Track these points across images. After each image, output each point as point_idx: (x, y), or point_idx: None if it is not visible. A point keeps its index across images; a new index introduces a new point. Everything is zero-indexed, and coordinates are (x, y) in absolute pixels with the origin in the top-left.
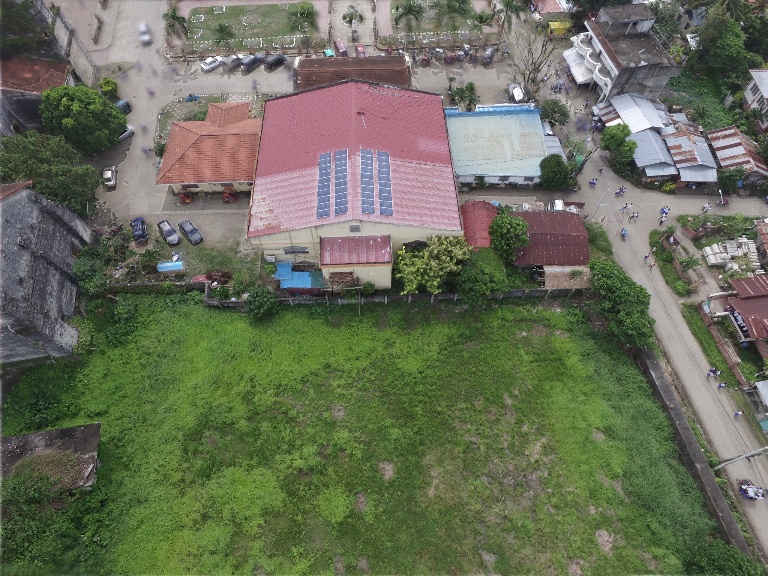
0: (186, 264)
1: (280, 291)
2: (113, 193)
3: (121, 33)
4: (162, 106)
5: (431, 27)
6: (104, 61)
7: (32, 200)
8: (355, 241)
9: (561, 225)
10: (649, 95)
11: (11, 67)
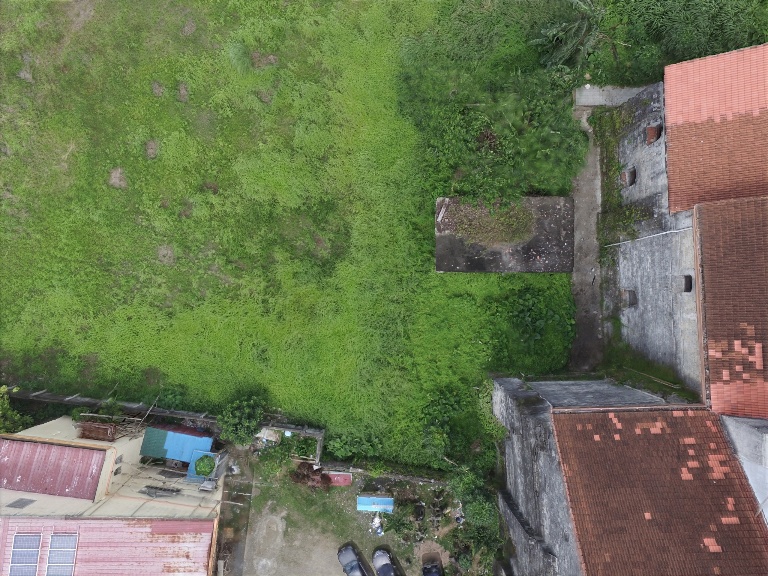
0: None
1: None
2: None
3: None
4: None
5: None
6: None
7: None
8: (44, 485)
9: None
10: None
11: None
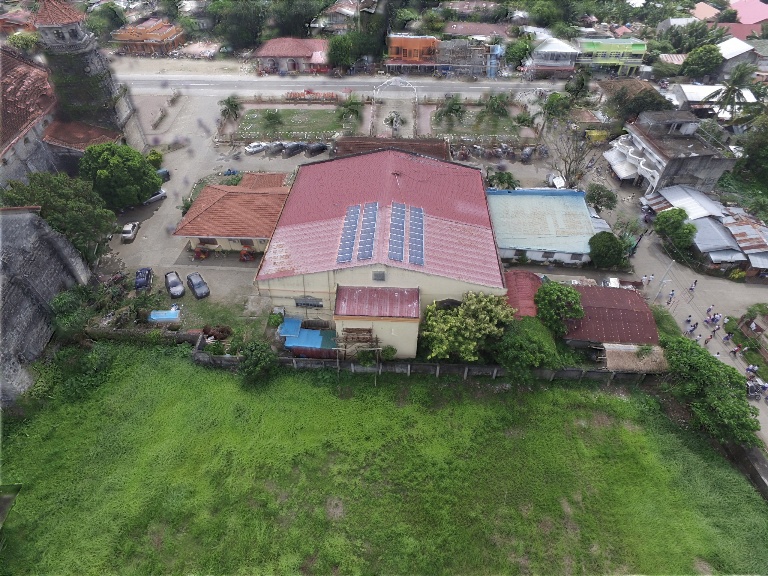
0: (185, 316)
1: (284, 352)
2: (129, 245)
3: (179, 123)
4: (200, 177)
5: (469, 131)
6: (157, 142)
7: (35, 224)
8: (377, 292)
9: (620, 301)
10: (702, 188)
11: (66, 129)
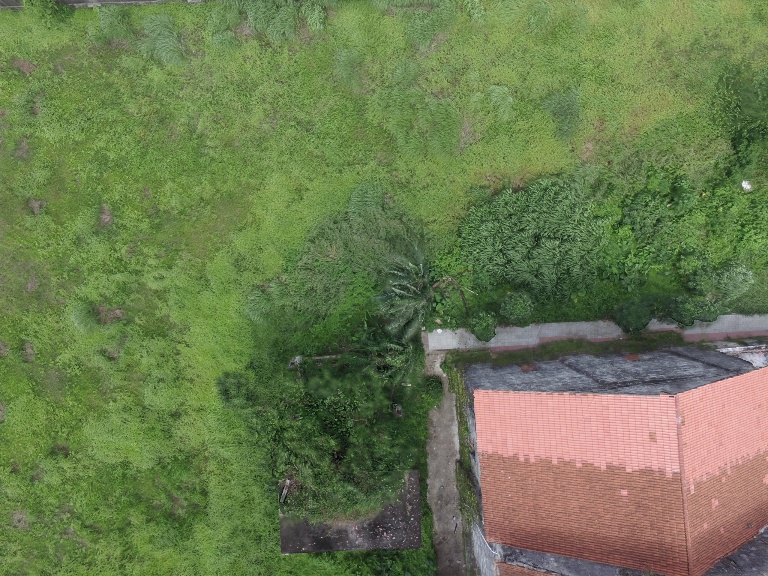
0: None
1: None
2: None
3: None
4: None
5: None
6: None
7: None
8: None
9: None
10: None
11: None
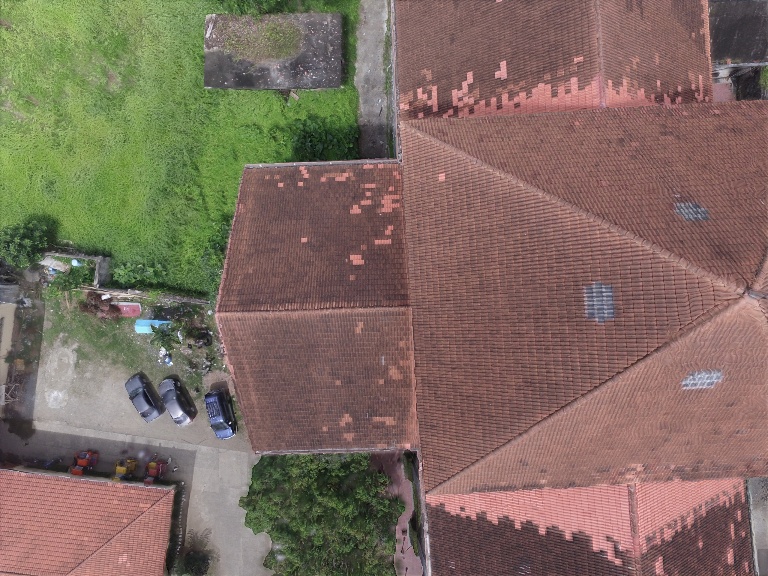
0: None
1: (15, 272)
2: None
3: None
4: None
5: None
6: None
7: None
8: None
9: None
10: None
11: None
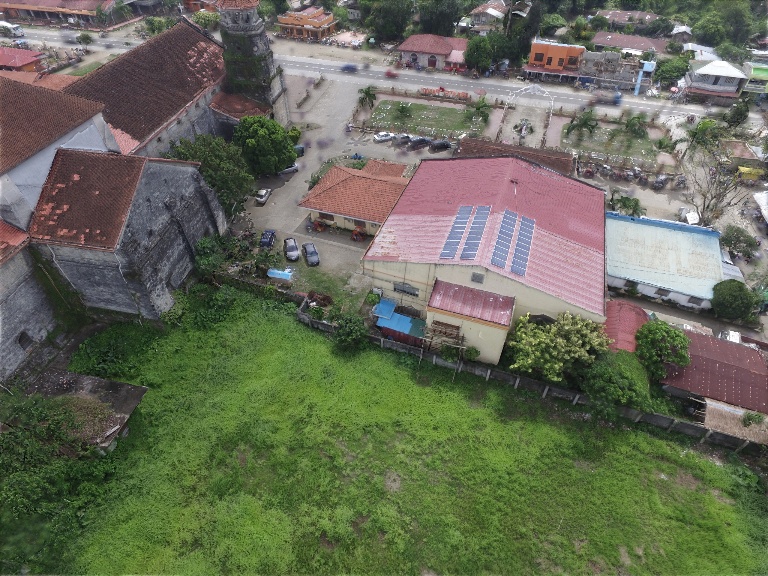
0: (295, 279)
1: (374, 331)
2: (260, 208)
3: (320, 105)
4: (330, 157)
5: (601, 149)
6: (298, 120)
7: (193, 177)
8: (473, 293)
9: (737, 357)
10: None
11: (229, 99)
